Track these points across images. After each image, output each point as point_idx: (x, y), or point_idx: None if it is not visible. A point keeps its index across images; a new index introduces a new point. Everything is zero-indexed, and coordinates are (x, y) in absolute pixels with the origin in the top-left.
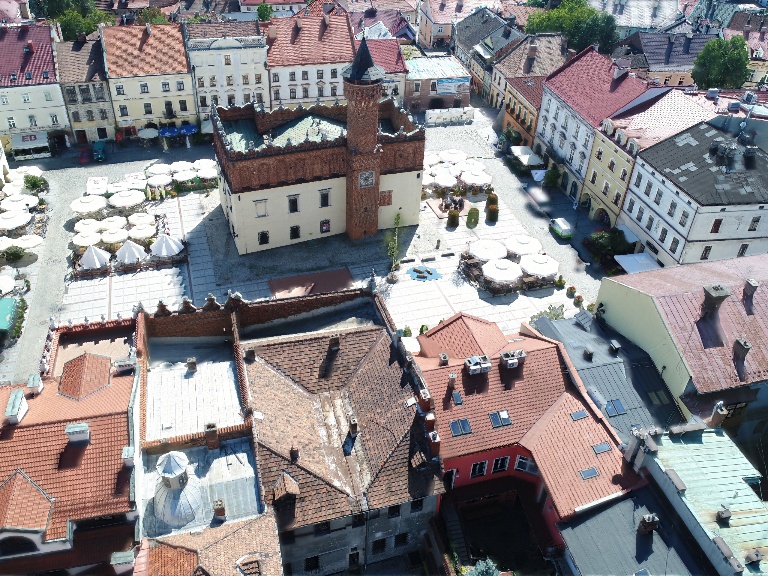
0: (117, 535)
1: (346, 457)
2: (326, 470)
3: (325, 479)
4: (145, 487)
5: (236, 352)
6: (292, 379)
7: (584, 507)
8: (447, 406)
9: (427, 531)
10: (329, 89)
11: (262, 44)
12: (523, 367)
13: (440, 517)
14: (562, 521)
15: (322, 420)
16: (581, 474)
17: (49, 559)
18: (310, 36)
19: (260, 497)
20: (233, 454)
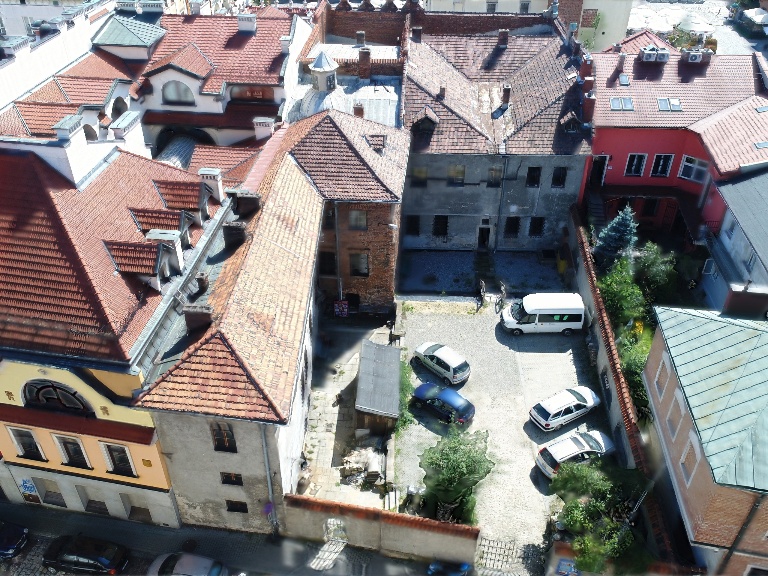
0: (263, 112)
1: (493, 119)
2: (470, 118)
3: (467, 120)
4: (296, 92)
5: (404, 31)
6: (454, 66)
7: (752, 163)
8: (611, 85)
9: (566, 224)
10: None
11: None
12: (707, 67)
13: (583, 204)
14: (722, 180)
15: (476, 97)
16: (756, 145)
17: (203, 117)
18: None
19: (399, 117)
20: (382, 85)
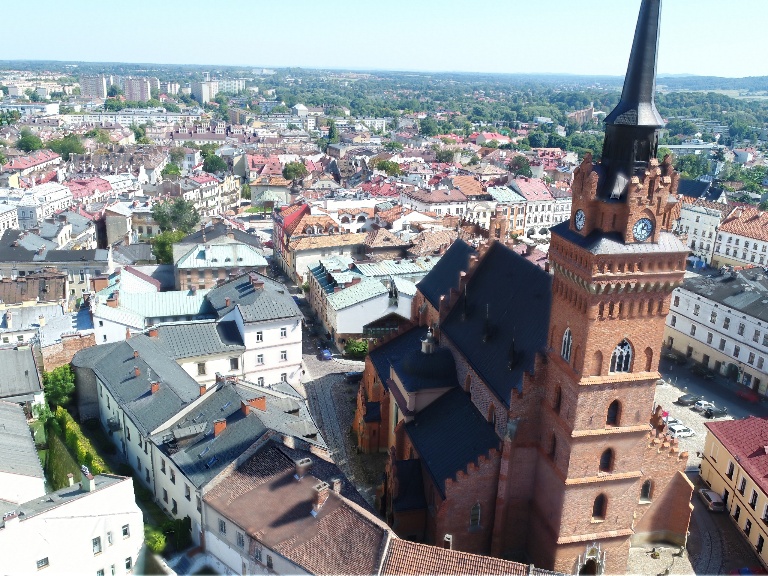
0: None
1: None
2: None
3: (422, 246)
4: None
5: None
6: None
7: None
8: None
9: None
10: (750, 256)
11: (718, 215)
12: None
13: None
14: None
15: None
16: None
17: None
18: (760, 222)
19: None
20: None
